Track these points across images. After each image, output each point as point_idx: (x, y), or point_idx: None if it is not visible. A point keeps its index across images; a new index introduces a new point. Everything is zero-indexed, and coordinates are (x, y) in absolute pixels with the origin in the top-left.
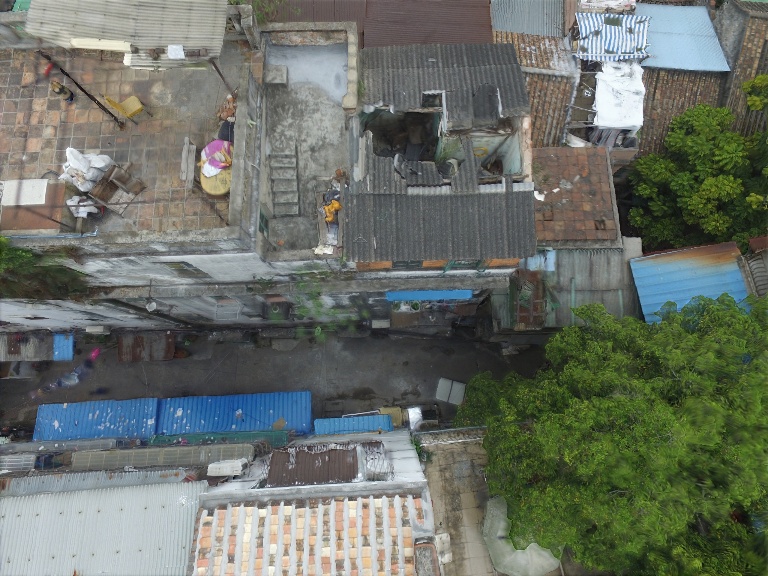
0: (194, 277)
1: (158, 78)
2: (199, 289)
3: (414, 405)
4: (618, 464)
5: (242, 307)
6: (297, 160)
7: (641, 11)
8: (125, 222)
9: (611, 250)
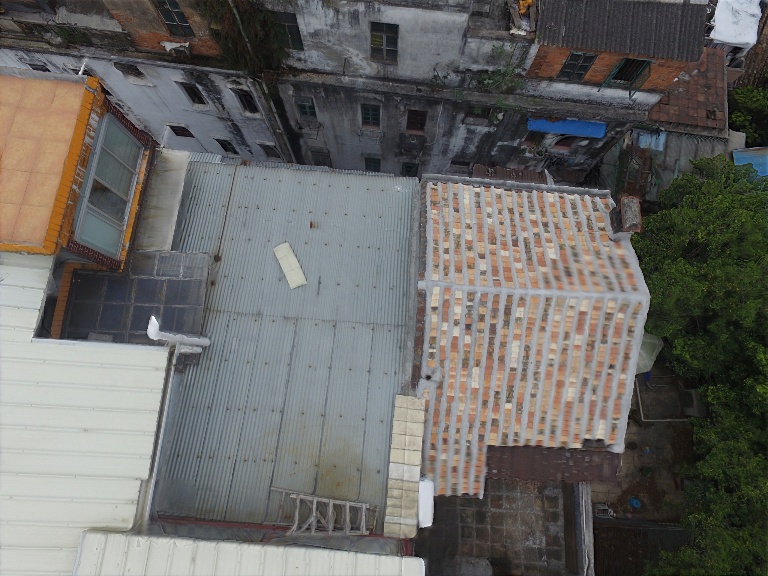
0: (382, 63)
1: None
2: (375, 84)
3: None
4: (752, 231)
5: (381, 136)
6: None
7: None
8: None
9: (717, 139)
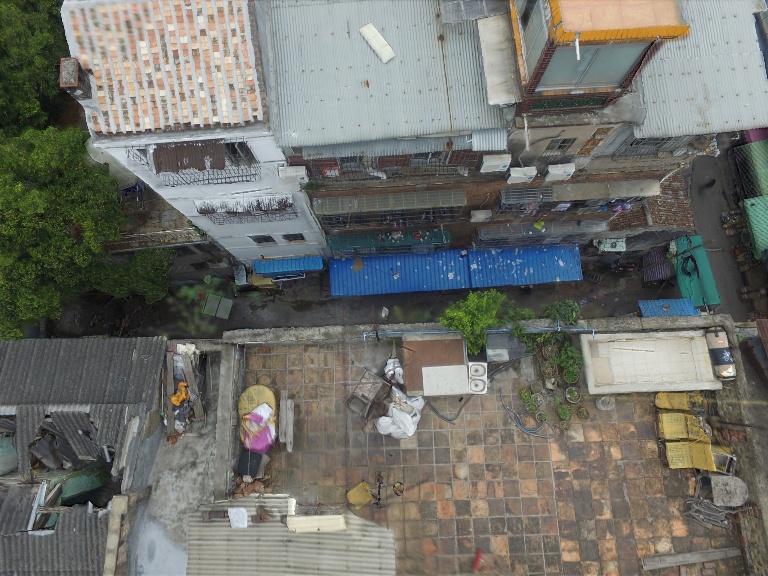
0: None
1: None
2: None
3: (255, 296)
4: None
5: None
6: (212, 452)
7: None
8: (362, 363)
9: None
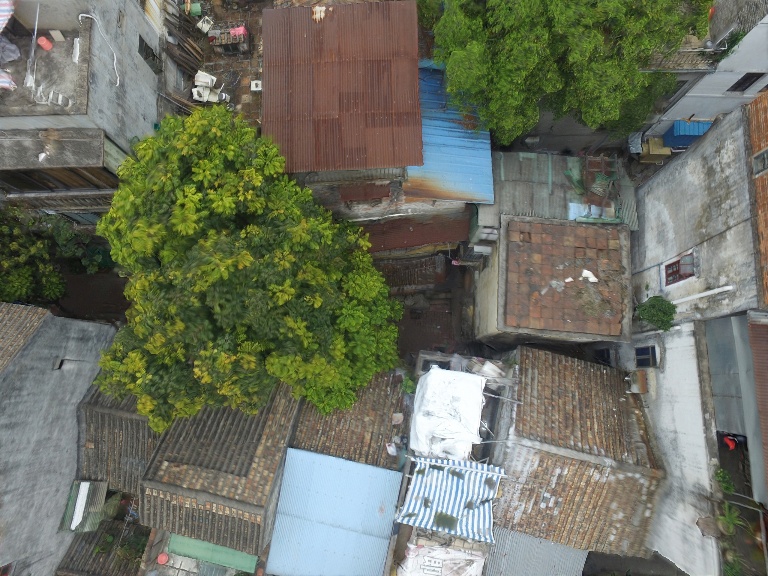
0: None
1: None
2: None
3: None
4: None
5: None
6: None
7: (355, 574)
8: None
9: None
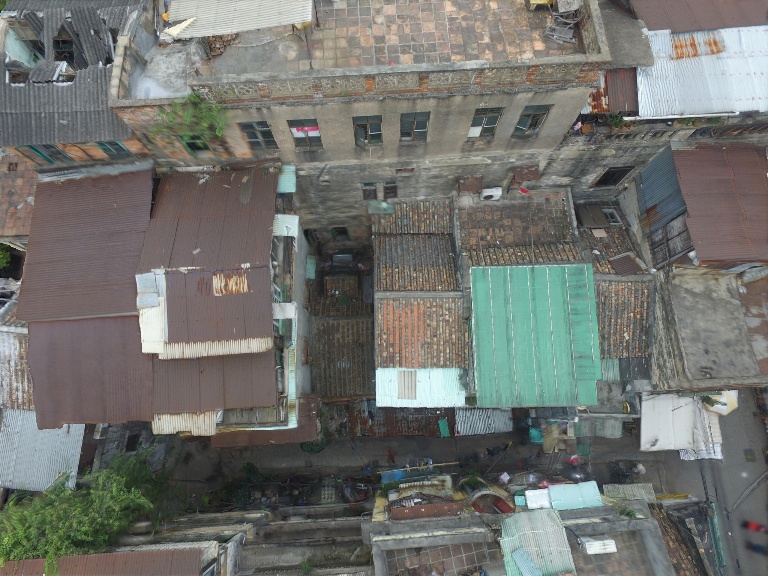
0: None
1: (291, 62)
2: None
3: None
4: None
5: None
6: None
7: None
8: None
9: None
